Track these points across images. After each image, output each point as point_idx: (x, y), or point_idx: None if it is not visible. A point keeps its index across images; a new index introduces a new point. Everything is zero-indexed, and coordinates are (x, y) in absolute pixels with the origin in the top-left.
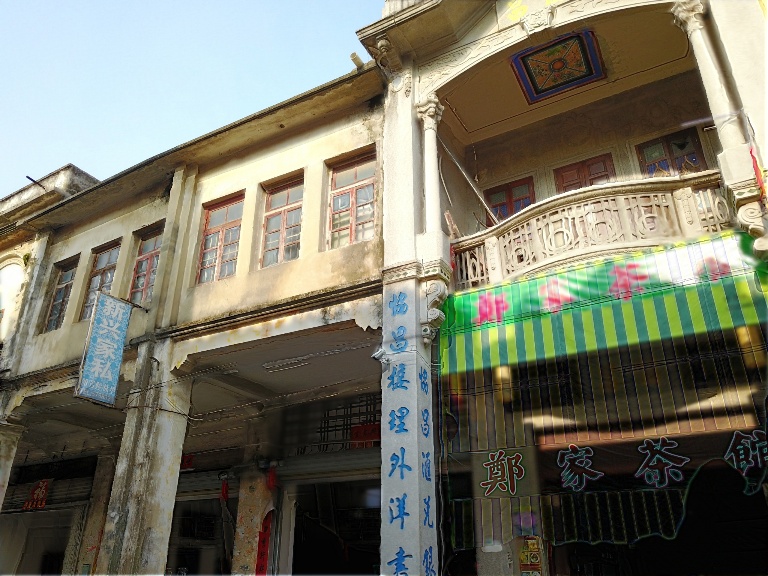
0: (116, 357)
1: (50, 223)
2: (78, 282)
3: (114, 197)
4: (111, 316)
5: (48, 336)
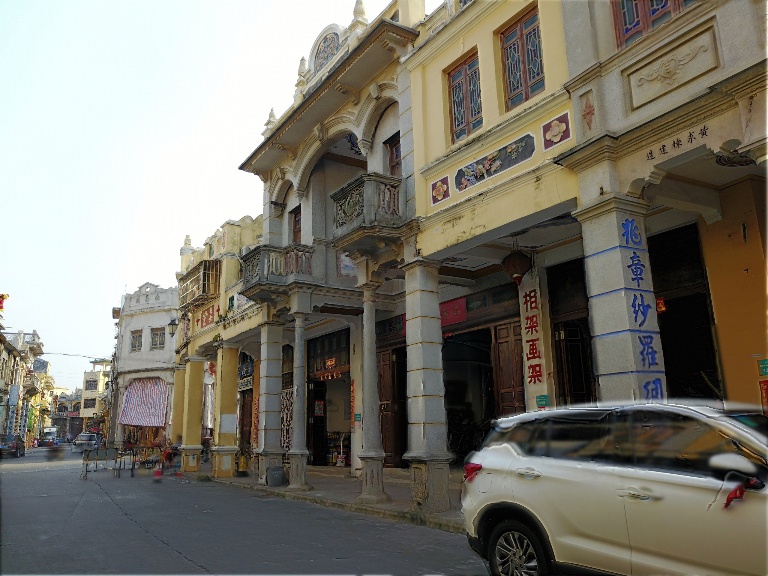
0: None
1: (5, 343)
2: None
3: None
4: None
5: None
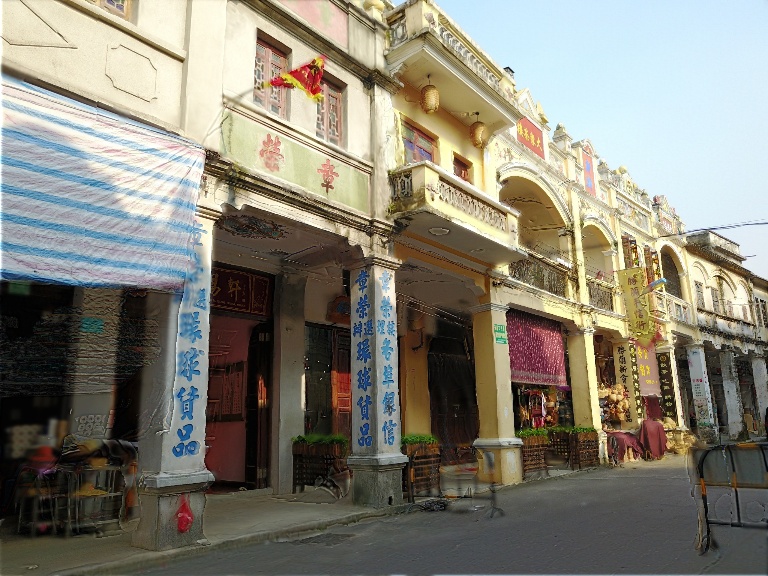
0: None
1: None
2: (761, 311)
3: (765, 284)
4: None
5: (761, 329)
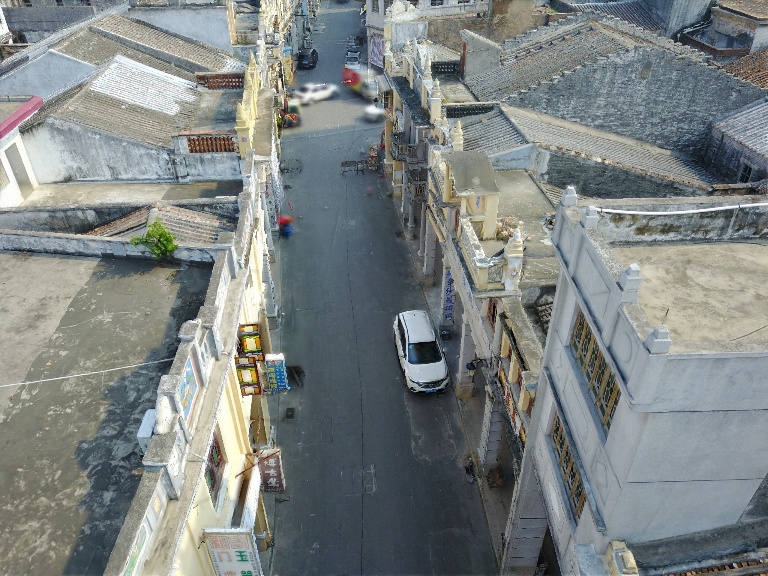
0: (303, 8)
1: None
2: None
3: None
4: (305, 3)
5: None
